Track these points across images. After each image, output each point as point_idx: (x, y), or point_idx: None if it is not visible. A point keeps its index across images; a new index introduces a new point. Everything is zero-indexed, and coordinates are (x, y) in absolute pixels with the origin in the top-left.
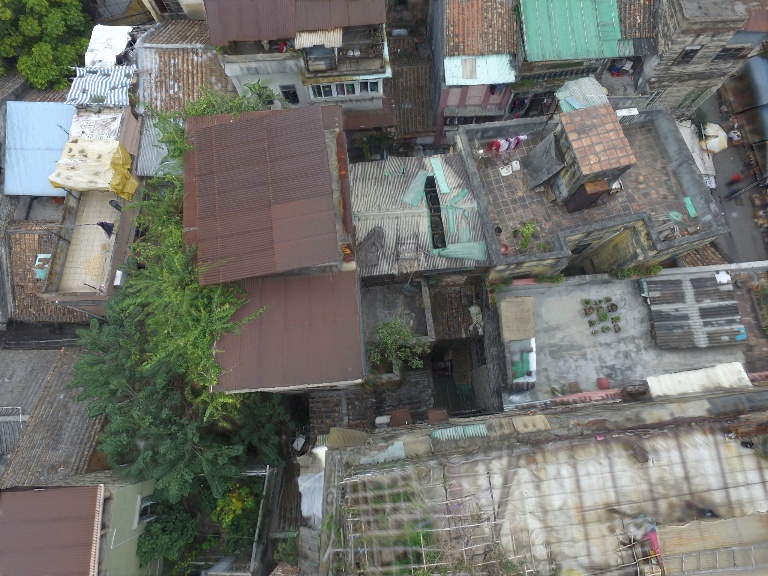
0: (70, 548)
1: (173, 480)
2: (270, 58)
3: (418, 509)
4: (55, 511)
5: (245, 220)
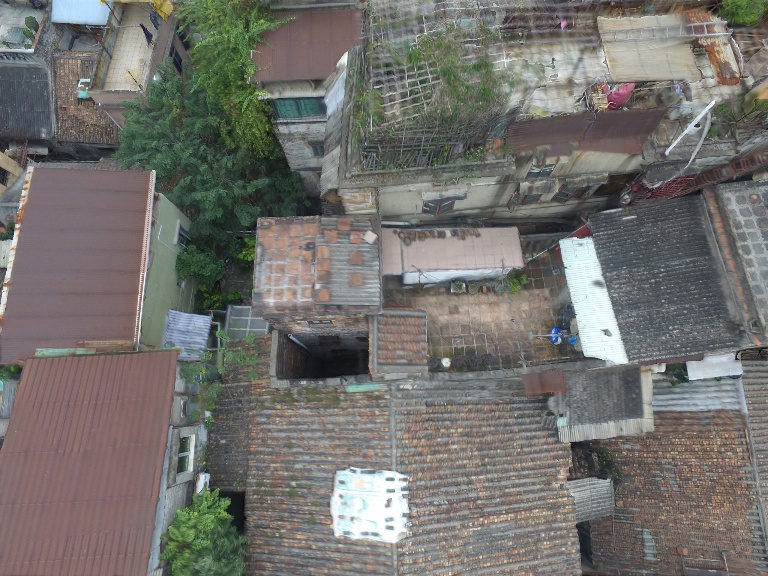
0: (128, 213)
1: (210, 192)
2: None
3: (422, 3)
4: (115, 186)
5: None
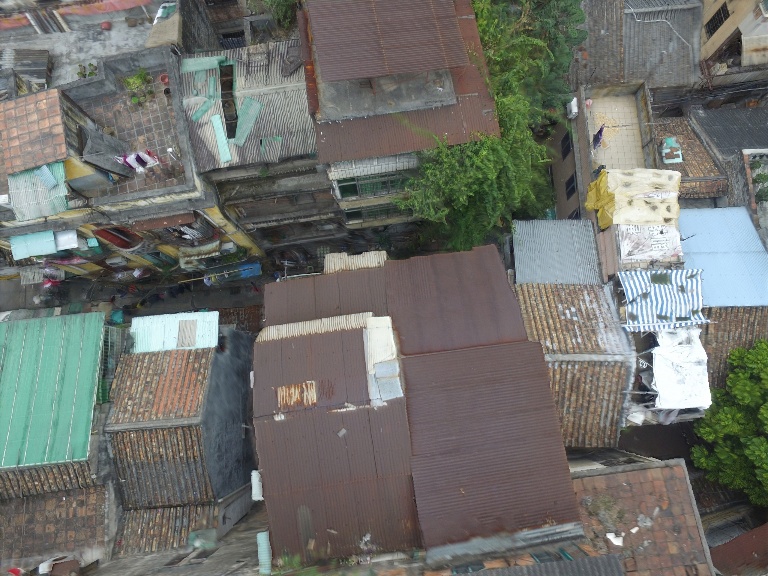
0: None
1: None
2: None
3: None
4: None
5: None
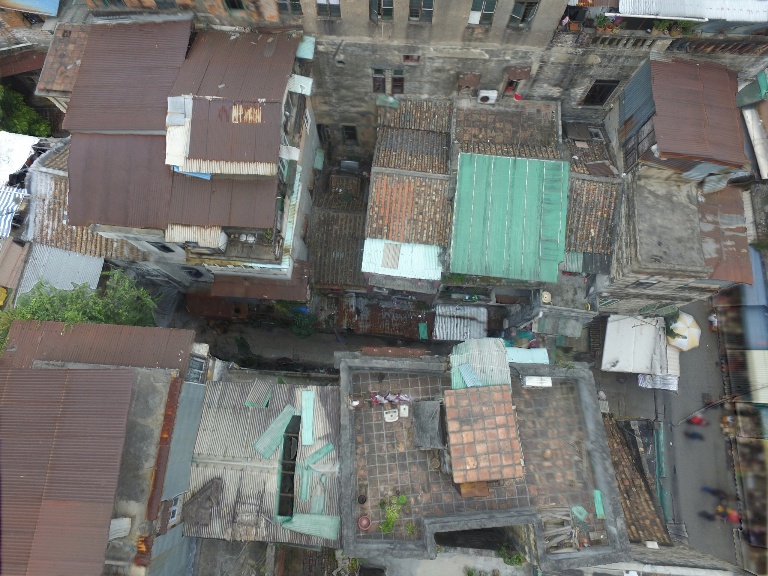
0: None
1: None
2: (147, 234)
3: None
4: None
5: (7, 514)
